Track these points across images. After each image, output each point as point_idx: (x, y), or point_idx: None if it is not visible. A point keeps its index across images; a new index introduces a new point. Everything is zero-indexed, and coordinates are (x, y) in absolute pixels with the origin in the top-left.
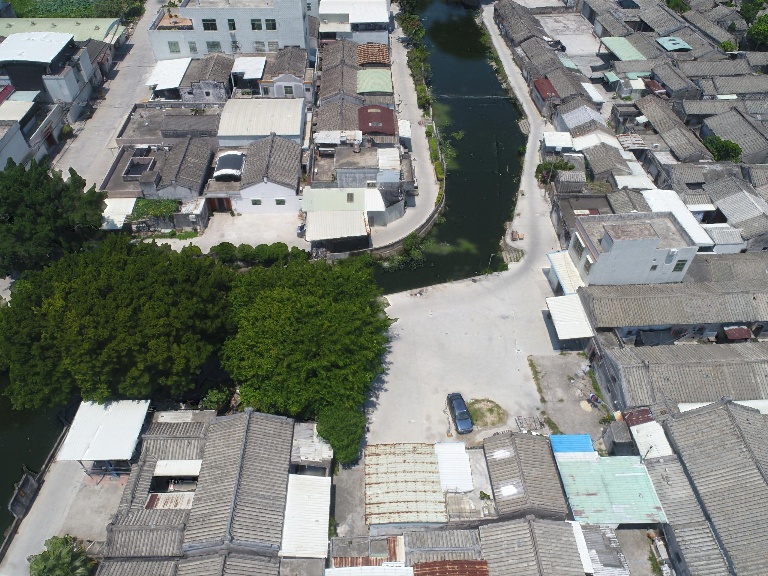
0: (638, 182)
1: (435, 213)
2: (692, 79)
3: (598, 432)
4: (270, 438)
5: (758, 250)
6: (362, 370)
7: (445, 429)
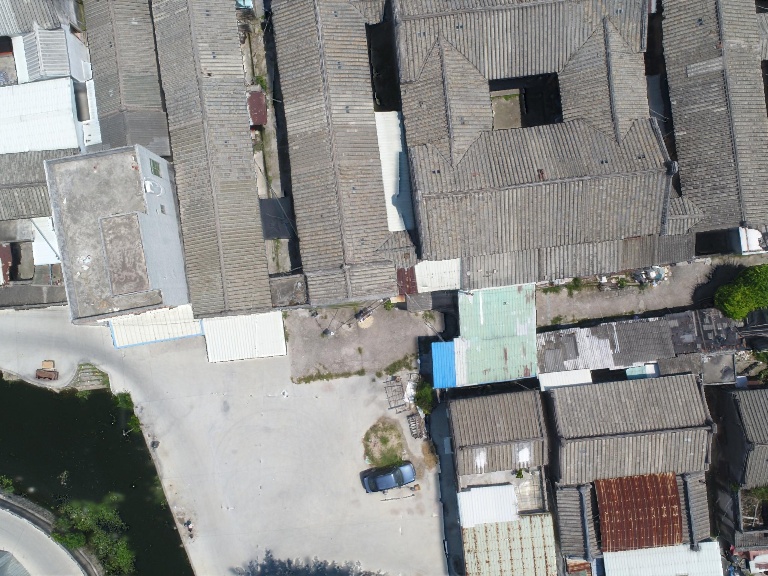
0: None
1: None
2: None
3: (402, 314)
4: None
5: (68, 6)
6: None
7: (409, 493)
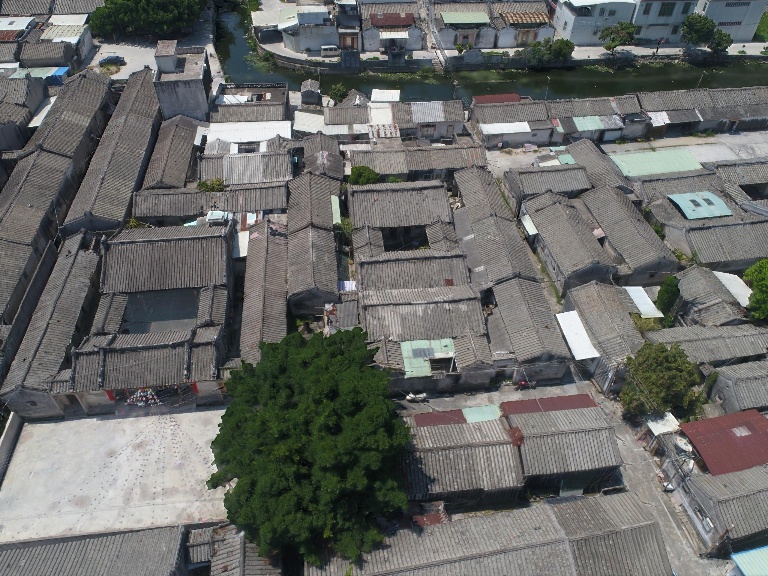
0: (308, 124)
1: (300, 64)
2: (560, 193)
3: None
4: (103, 5)
5: None
6: (119, 7)
7: None
